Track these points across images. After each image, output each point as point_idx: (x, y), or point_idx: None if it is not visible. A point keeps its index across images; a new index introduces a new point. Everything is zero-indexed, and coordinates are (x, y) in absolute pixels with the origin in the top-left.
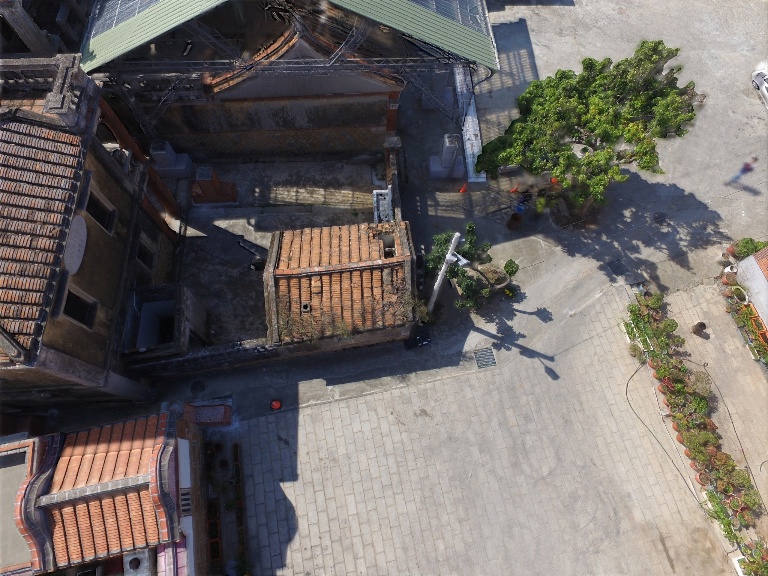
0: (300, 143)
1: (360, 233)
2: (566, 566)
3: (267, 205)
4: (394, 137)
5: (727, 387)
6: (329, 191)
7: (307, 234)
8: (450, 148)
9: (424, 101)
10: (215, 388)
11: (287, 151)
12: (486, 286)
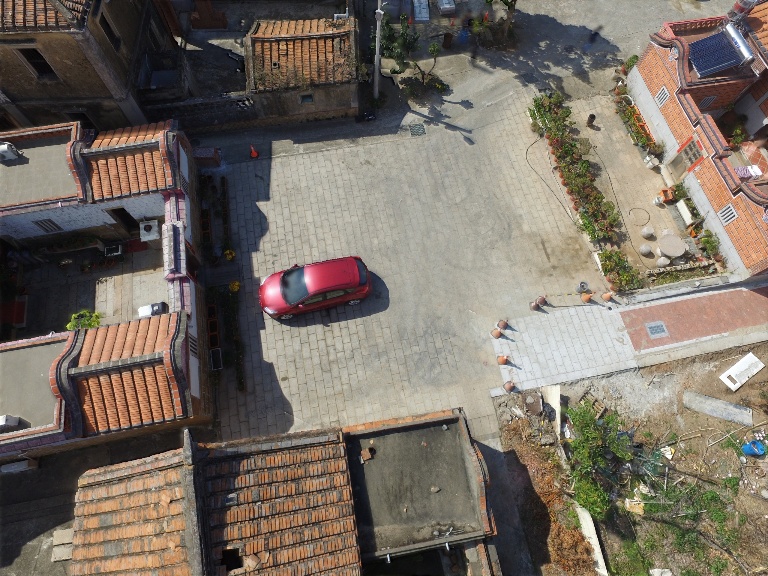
0: None
1: (319, 23)
2: (468, 256)
3: None
4: None
5: (610, 162)
6: None
7: (278, 23)
8: None
9: None
10: (208, 144)
11: None
12: (422, 83)
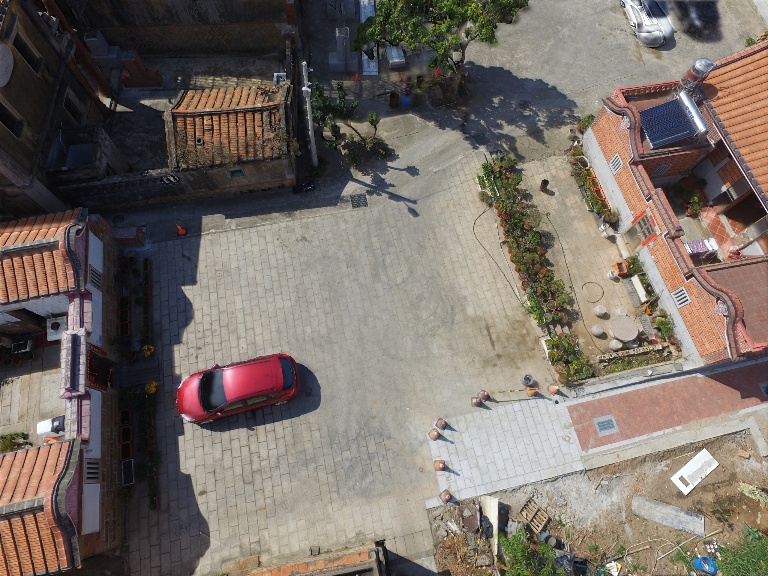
0: (217, 39)
1: (250, 91)
2: (408, 344)
3: (187, 89)
4: (289, 25)
5: (564, 230)
6: (241, 79)
7: (207, 92)
8: (340, 39)
9: (329, 10)
10: (133, 220)
11: (207, 48)
12: None
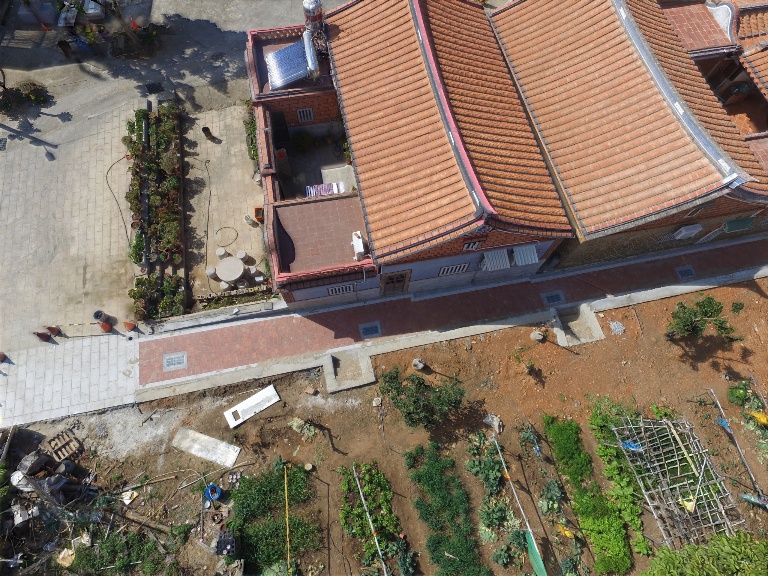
0: None
1: None
2: None
3: None
4: None
5: (218, 177)
6: None
7: None
8: None
9: None
10: None
11: None
12: (21, 95)
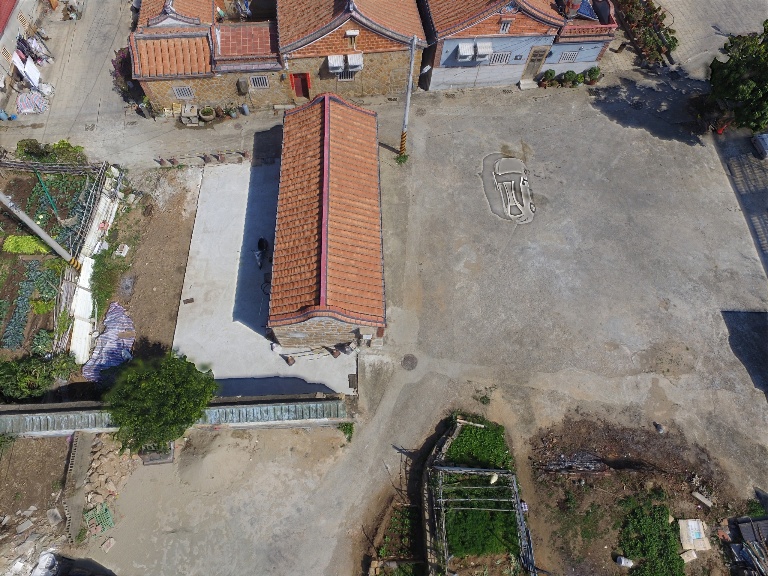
0: None
1: None
2: None
3: None
4: None
5: None
6: None
7: None
8: None
9: None
10: None
11: None
12: None
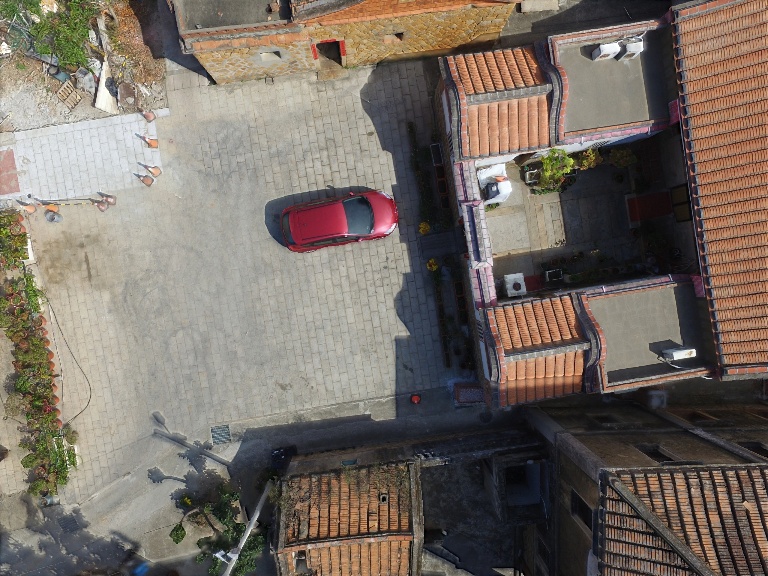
0: None
1: None
2: (176, 262)
3: None
4: None
5: None
6: None
7: None
8: None
9: None
10: (471, 416)
11: None
12: None
